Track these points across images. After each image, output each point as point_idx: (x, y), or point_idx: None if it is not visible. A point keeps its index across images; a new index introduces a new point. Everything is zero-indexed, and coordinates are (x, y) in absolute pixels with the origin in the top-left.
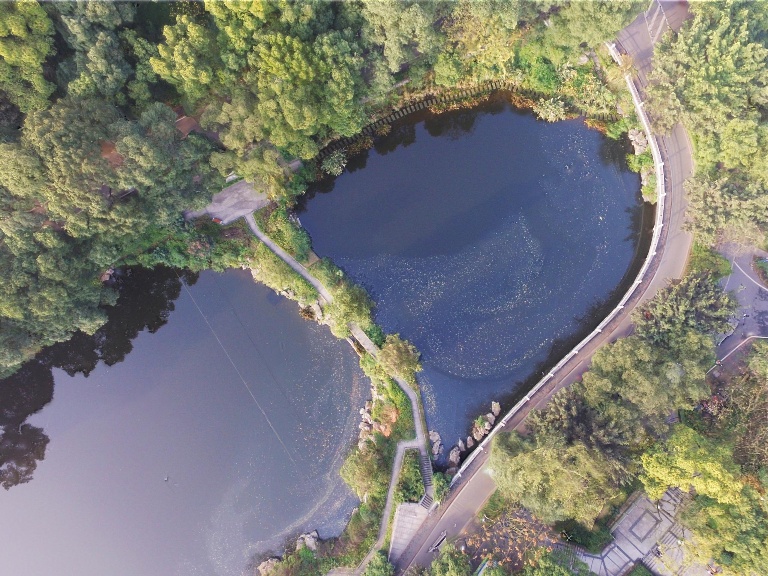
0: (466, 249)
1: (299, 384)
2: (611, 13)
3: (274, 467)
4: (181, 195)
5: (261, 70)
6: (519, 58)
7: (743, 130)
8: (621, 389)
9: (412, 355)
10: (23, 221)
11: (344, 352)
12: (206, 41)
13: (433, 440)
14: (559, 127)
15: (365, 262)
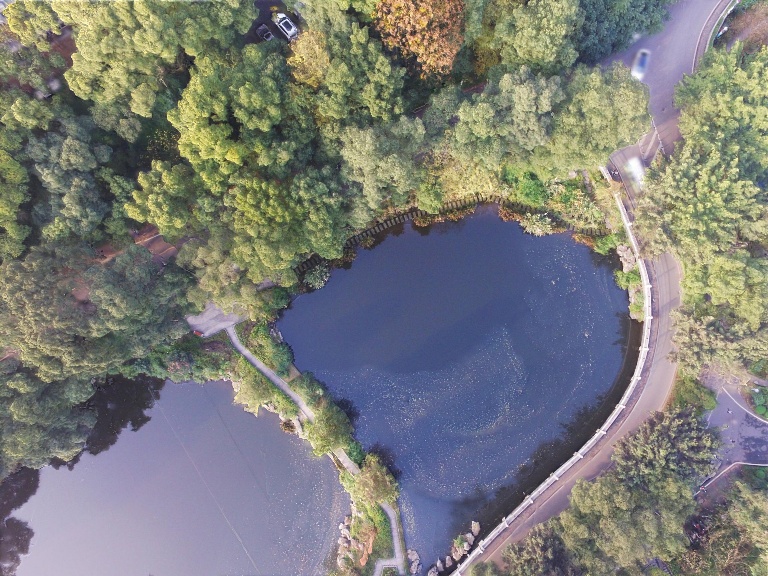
0: (449, 365)
1: (279, 498)
2: (597, 151)
3: None
4: (157, 330)
5: (238, 212)
6: (506, 172)
7: (731, 269)
8: (597, 539)
9: (389, 486)
10: None
11: (324, 466)
12: (181, 187)
13: (411, 559)
14: (546, 241)
15: (346, 377)
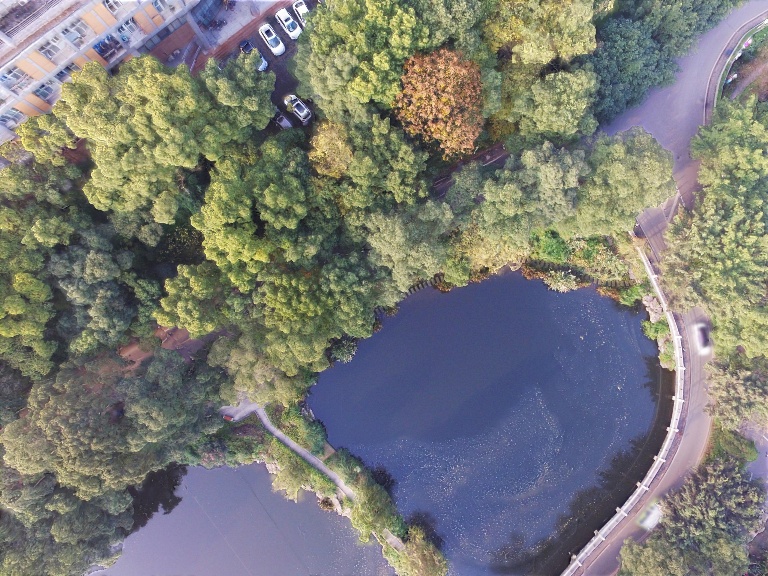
0: (484, 430)
1: None
2: (623, 216)
3: None
4: (192, 431)
5: (267, 308)
6: None
7: (764, 323)
8: None
9: (438, 565)
10: (34, 497)
11: None
12: (210, 291)
13: None
14: (571, 297)
15: (382, 450)
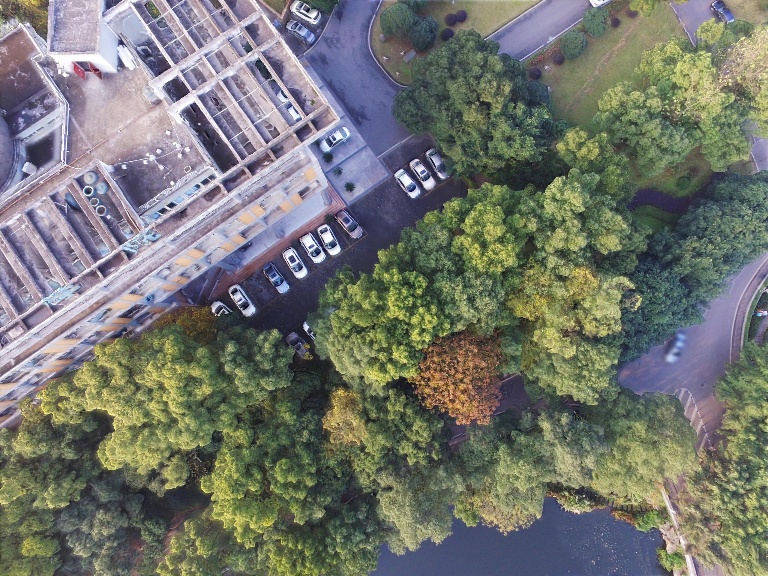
0: None
1: None
2: (642, 481)
3: None
4: None
5: (272, 562)
6: None
7: None
8: None
9: None
10: None
11: None
12: (215, 549)
13: None
14: (584, 518)
15: None
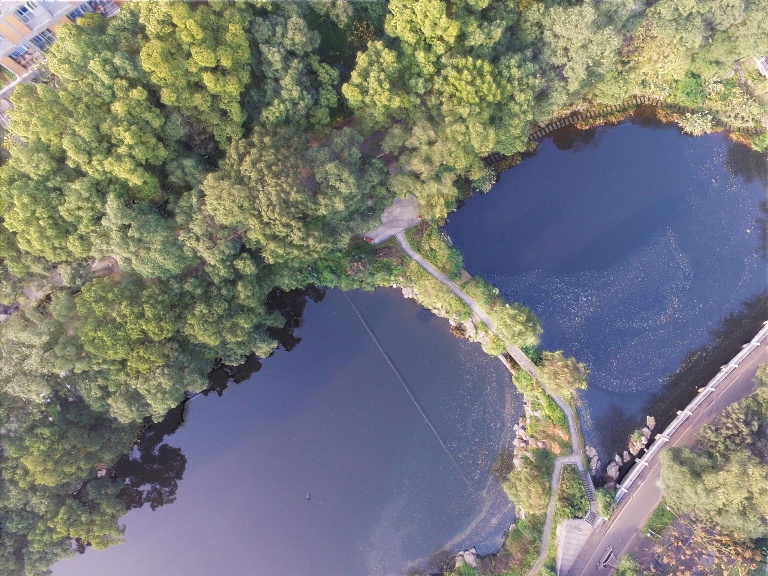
0: (616, 264)
1: (452, 401)
2: None
3: (430, 485)
4: (361, 218)
5: (447, 93)
6: (665, 73)
7: None
8: None
9: (583, 373)
10: (226, 249)
11: (496, 369)
12: (398, 66)
13: (590, 455)
14: (704, 141)
15: (516, 279)
